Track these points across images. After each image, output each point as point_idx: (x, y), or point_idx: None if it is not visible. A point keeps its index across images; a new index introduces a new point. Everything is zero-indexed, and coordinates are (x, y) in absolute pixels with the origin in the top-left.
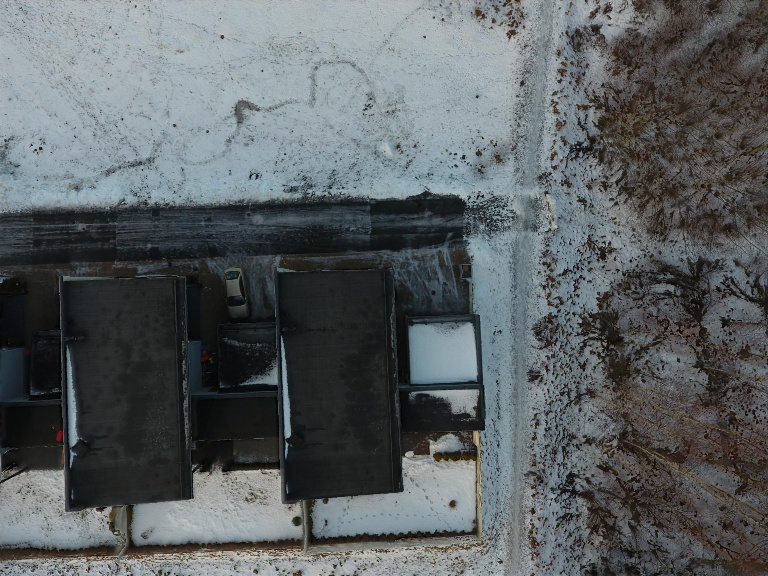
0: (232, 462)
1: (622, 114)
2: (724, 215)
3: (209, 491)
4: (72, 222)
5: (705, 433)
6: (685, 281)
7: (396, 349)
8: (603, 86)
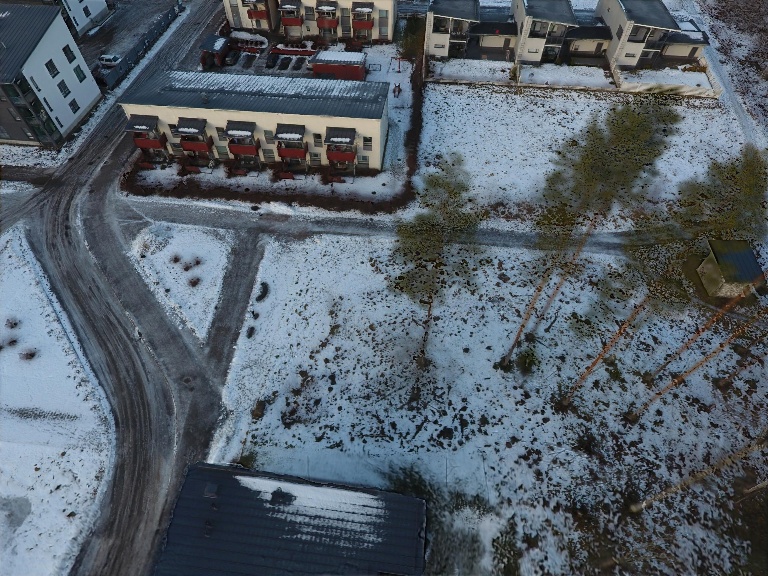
0: None
1: None
2: None
3: (561, 71)
4: None
5: None
6: None
7: None
8: (715, 5)
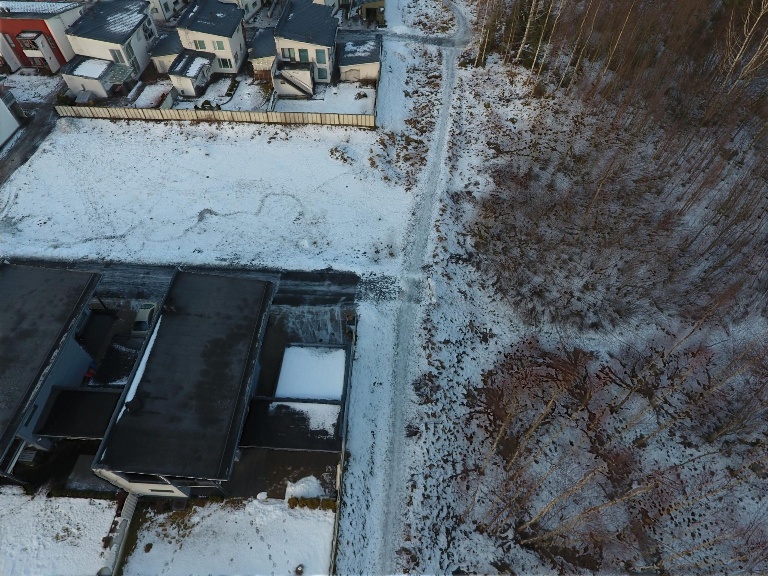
0: (63, 487)
1: (492, 241)
2: (589, 315)
3: (20, 520)
4: None
5: (617, 533)
6: (565, 367)
7: (261, 341)
8: (477, 224)
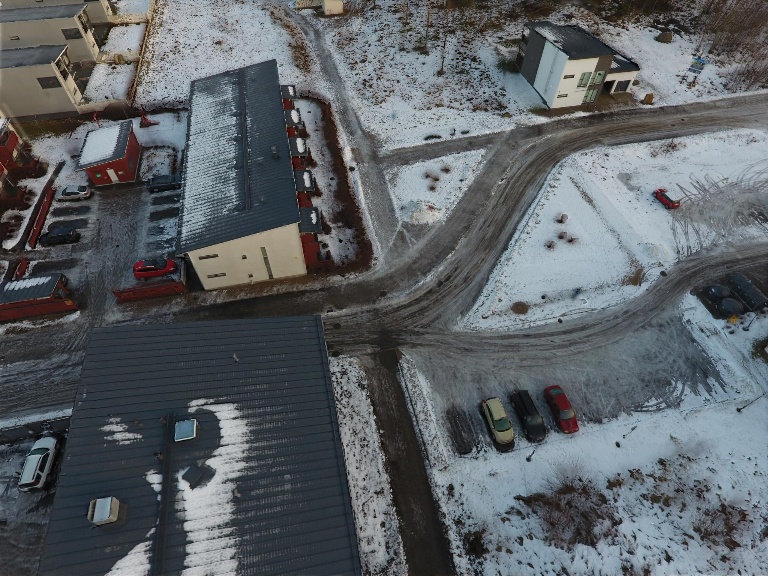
0: None
1: None
2: None
3: None
4: None
5: None
6: None
7: None
8: None
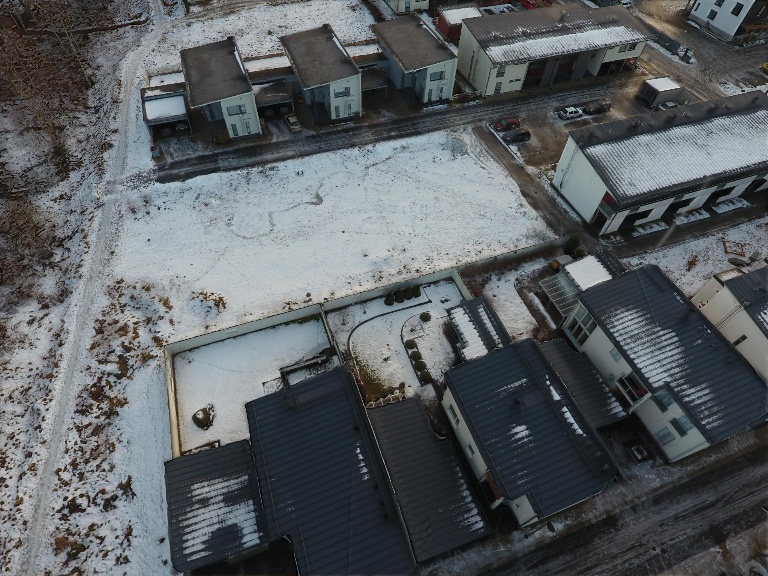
0: None
1: (32, 264)
2: None
3: None
4: (399, 134)
5: (8, 140)
6: (3, 196)
7: None
8: None
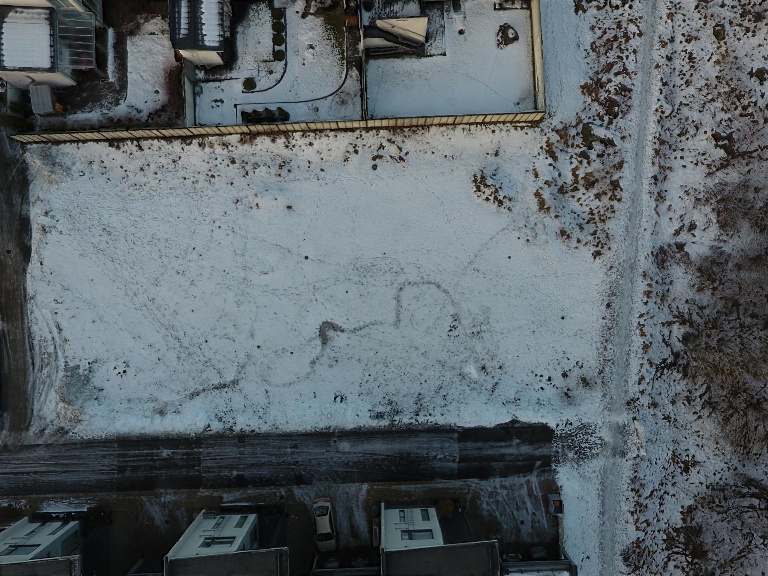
0: None
1: (706, 330)
2: None
3: None
4: (157, 448)
5: None
6: None
7: None
8: (687, 302)
